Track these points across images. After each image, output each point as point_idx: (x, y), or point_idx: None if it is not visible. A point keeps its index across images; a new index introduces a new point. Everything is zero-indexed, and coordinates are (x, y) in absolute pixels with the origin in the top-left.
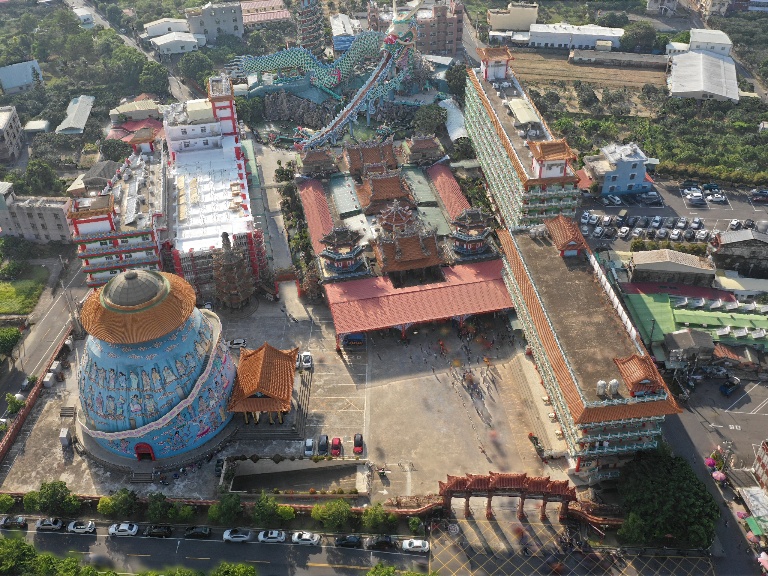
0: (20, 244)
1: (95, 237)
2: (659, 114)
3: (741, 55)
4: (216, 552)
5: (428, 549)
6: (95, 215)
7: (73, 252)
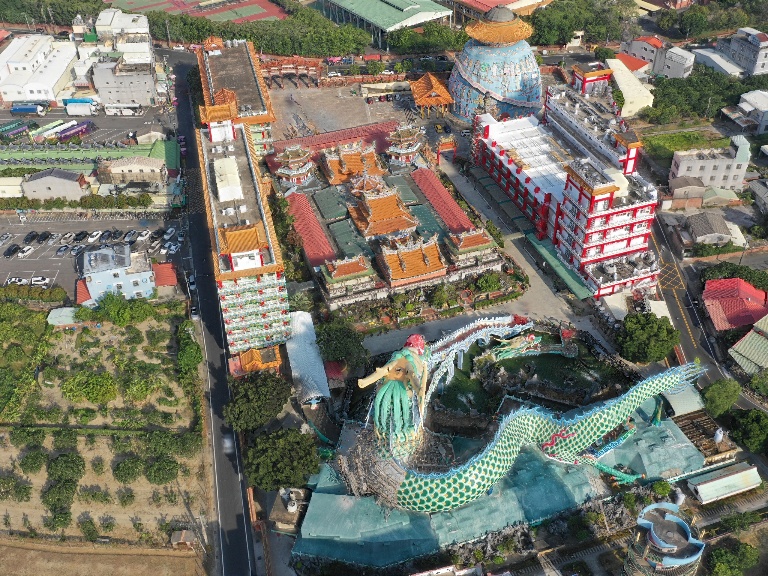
0: None
1: None
2: None
3: None
4: None
5: None
6: None
7: None
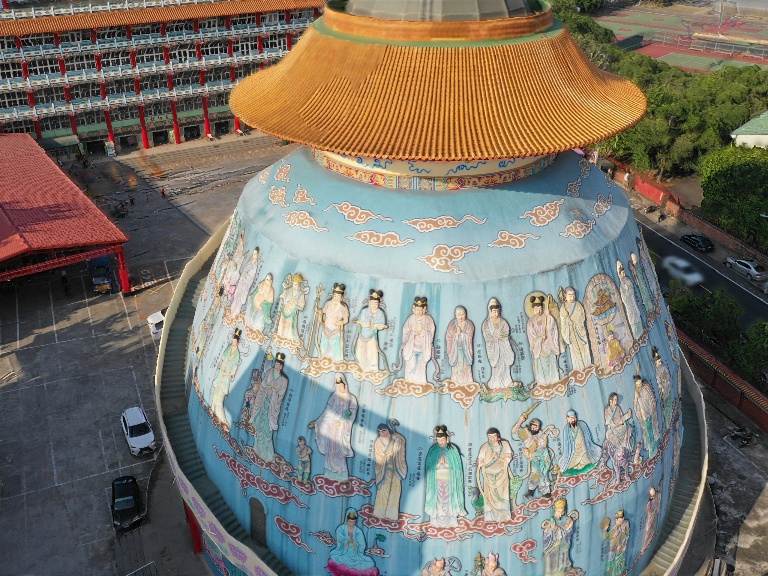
0: None
1: None
2: None
3: None
4: None
5: None
6: None
7: None
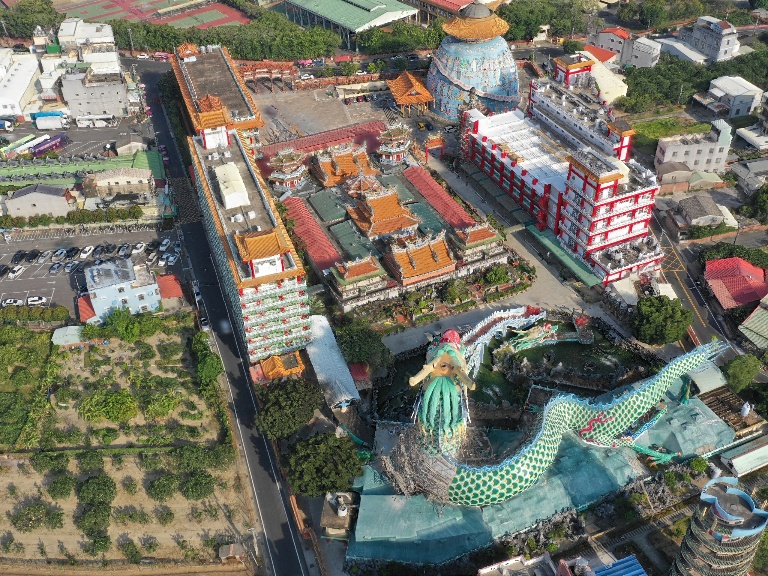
0: None
1: None
2: None
3: None
4: None
5: None
6: None
7: None
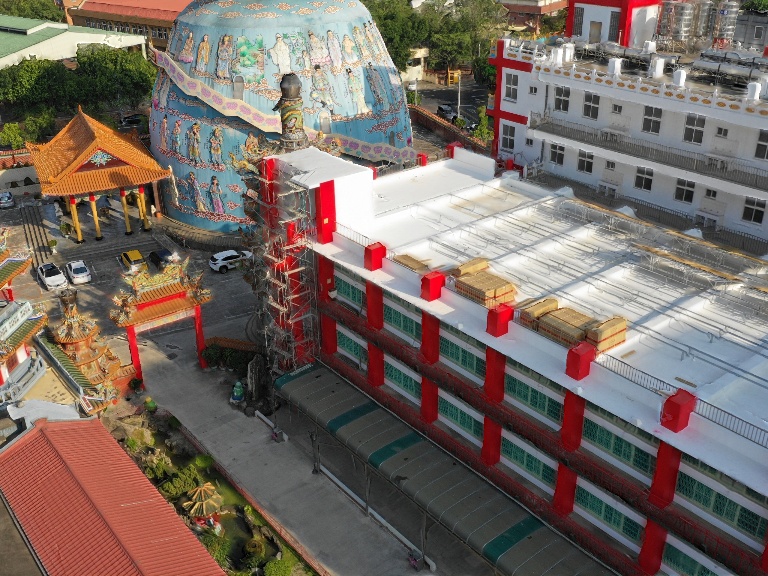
0: None
1: None
2: None
3: None
4: None
5: None
6: None
7: None
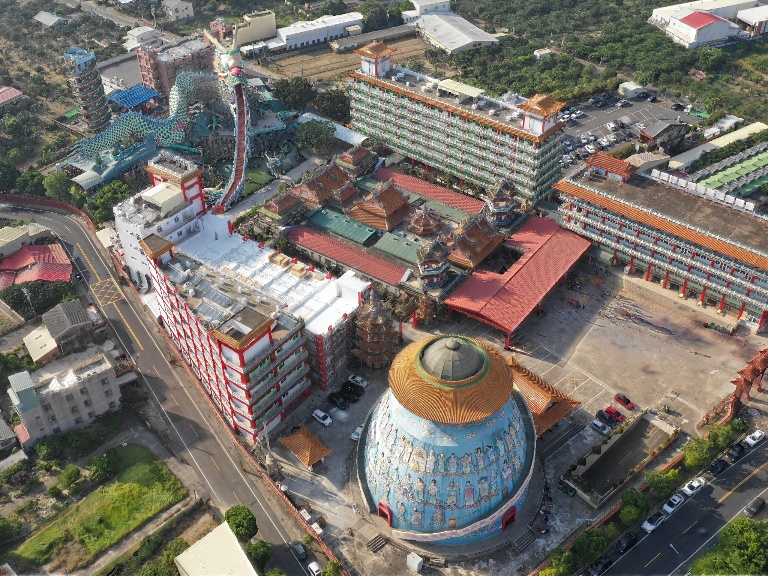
0: (71, 439)
1: (261, 358)
2: (461, 70)
3: (452, 9)
4: (656, 546)
5: (764, 435)
6: (262, 332)
7: (139, 413)
